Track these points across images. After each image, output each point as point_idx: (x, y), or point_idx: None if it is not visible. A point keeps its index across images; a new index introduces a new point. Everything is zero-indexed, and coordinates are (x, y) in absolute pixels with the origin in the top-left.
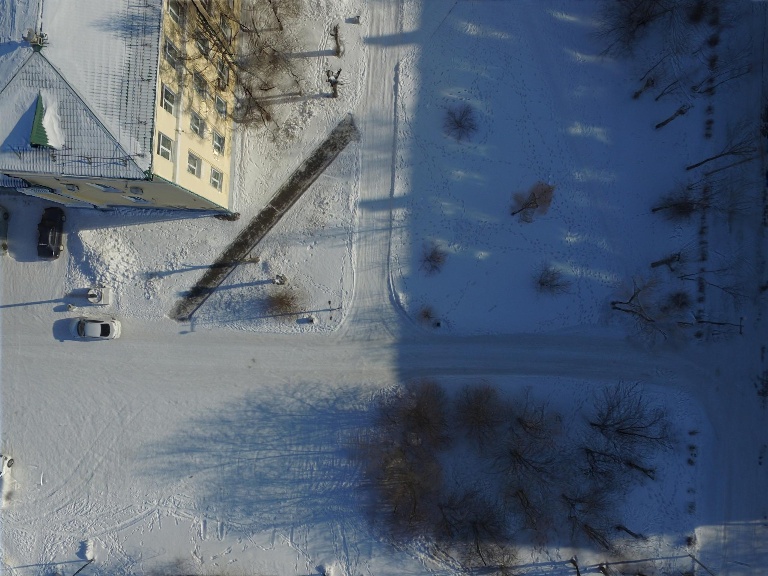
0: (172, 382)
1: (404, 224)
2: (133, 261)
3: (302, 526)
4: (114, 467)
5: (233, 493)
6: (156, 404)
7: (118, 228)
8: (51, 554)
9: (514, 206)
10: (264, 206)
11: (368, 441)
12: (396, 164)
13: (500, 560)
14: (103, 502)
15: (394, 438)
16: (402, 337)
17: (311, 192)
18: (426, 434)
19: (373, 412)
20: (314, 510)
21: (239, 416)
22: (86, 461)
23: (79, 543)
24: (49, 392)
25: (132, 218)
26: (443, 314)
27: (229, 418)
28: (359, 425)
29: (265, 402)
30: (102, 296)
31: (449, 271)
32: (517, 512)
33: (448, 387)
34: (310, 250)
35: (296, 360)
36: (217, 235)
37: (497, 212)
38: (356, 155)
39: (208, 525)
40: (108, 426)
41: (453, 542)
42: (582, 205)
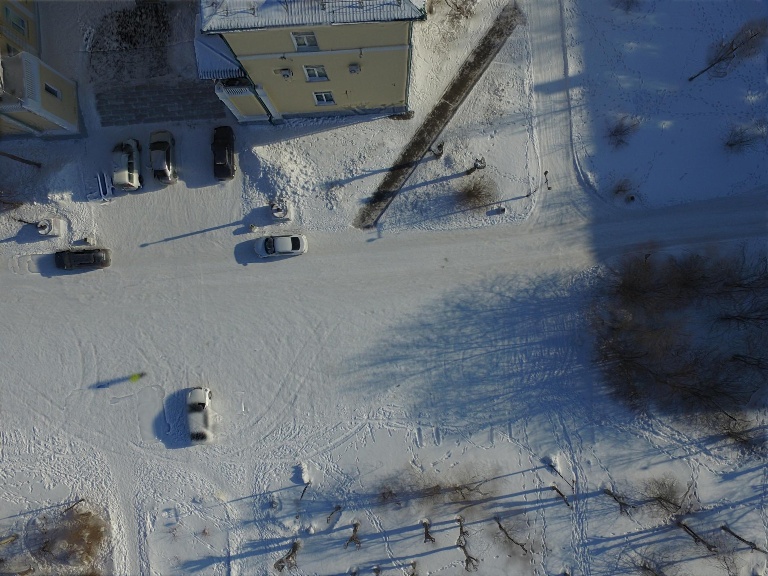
0: (365, 292)
1: (583, 102)
2: (311, 172)
3: (519, 420)
4: (317, 386)
5: (444, 396)
6: (352, 316)
7: (291, 141)
8: (264, 483)
9: (691, 71)
10: (437, 101)
11: (574, 326)
12: (567, 42)
13: (726, 427)
14: (311, 423)
15: (603, 318)
16: (595, 217)
17: (484, 81)
18: (638, 308)
19: (575, 296)
20: (529, 403)
21: (439, 318)
22: (287, 384)
23: (292, 468)
24: (239, 318)
25: (304, 129)
26: (634, 188)
27: (429, 321)
28: (563, 311)
29: (464, 300)
30: (287, 210)
31: (636, 143)
32: (742, 374)
33: (650, 260)
34: (491, 140)
35: (489, 254)
36: (394, 136)
37: (674, 79)
38: (525, 38)
39: (423, 432)
40: (305, 345)
41: (677, 415)
42: (759, 62)
